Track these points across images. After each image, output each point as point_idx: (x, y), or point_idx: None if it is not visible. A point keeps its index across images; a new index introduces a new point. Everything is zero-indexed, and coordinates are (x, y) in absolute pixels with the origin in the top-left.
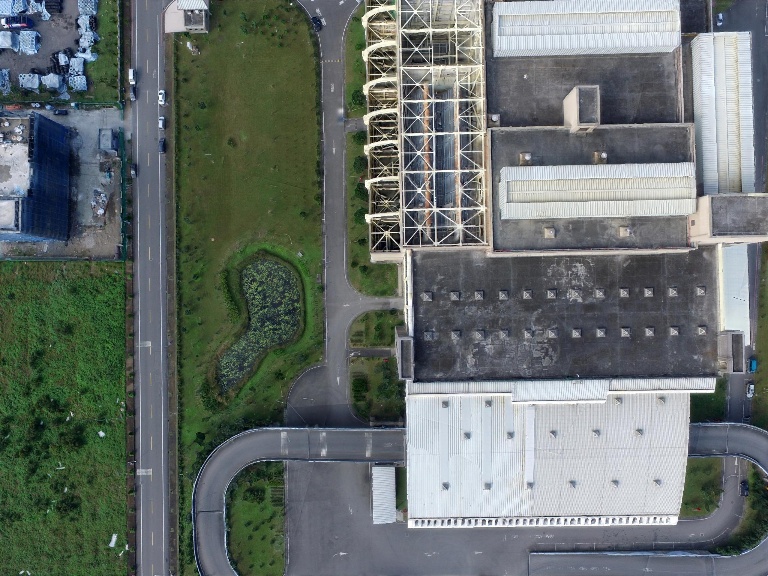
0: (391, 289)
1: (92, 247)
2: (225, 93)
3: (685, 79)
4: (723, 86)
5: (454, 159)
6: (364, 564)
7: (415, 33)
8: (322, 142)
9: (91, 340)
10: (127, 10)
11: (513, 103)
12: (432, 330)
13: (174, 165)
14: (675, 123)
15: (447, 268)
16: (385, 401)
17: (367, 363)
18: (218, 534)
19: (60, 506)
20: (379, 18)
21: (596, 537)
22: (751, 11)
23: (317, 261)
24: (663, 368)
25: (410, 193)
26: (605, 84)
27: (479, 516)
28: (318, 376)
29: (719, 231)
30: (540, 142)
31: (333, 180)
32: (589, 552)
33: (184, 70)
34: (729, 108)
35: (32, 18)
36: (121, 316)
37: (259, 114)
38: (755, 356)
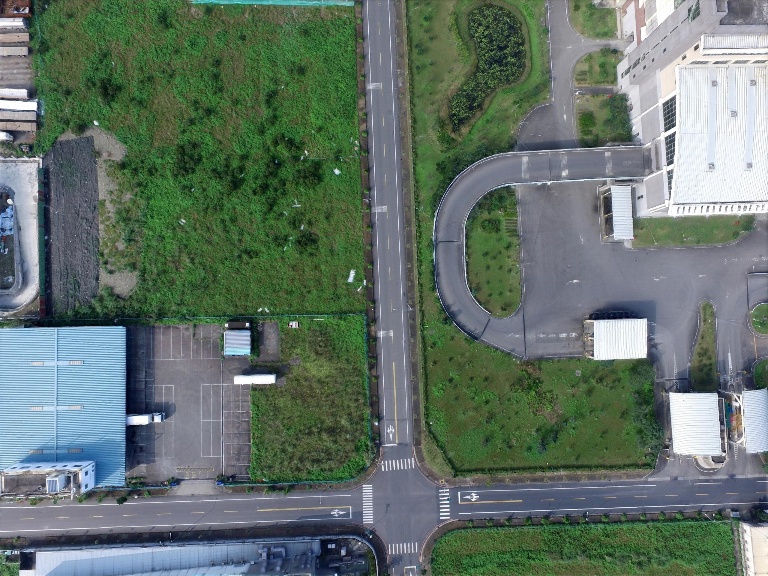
0: (611, 31)
1: None
2: None
3: None
4: None
5: None
6: (596, 290)
7: None
8: None
9: (324, 80)
10: None
11: None
12: None
13: None
14: None
15: None
16: (616, 129)
17: (592, 100)
18: (457, 264)
19: (300, 240)
20: None
21: None
22: None
23: (541, 6)
24: None
25: None
26: None
27: (737, 200)
28: (546, 114)
29: None
30: None
31: None
32: None
33: None
34: None
35: None
36: (353, 57)
37: None
38: None
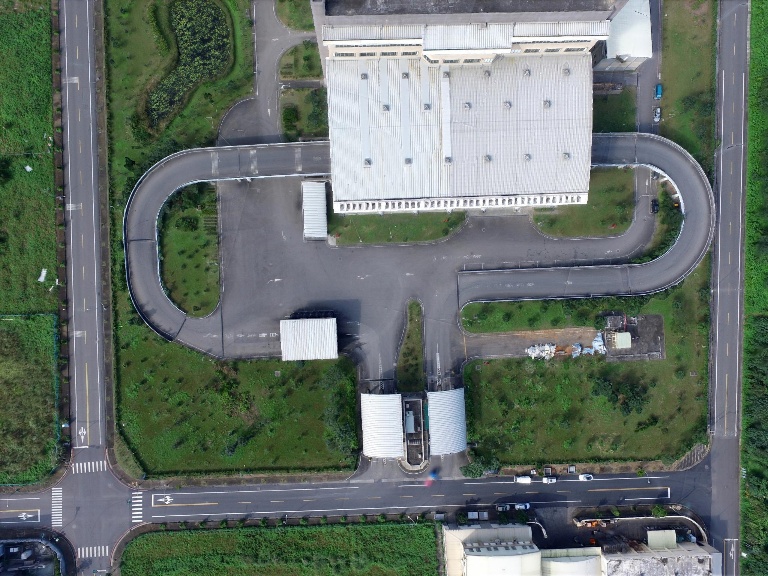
0: None
1: None
2: None
3: None
4: None
5: None
6: (299, 289)
7: None
8: None
9: (16, 75)
10: None
11: None
12: None
13: None
14: None
15: None
16: (314, 124)
17: (297, 94)
18: (151, 263)
19: None
20: None
21: (520, 256)
22: None
23: None
24: (560, 5)
25: None
26: None
27: (402, 197)
28: (249, 108)
29: None
30: None
31: None
32: (514, 269)
33: None
34: None
35: None
36: (47, 51)
37: None
38: (661, 84)
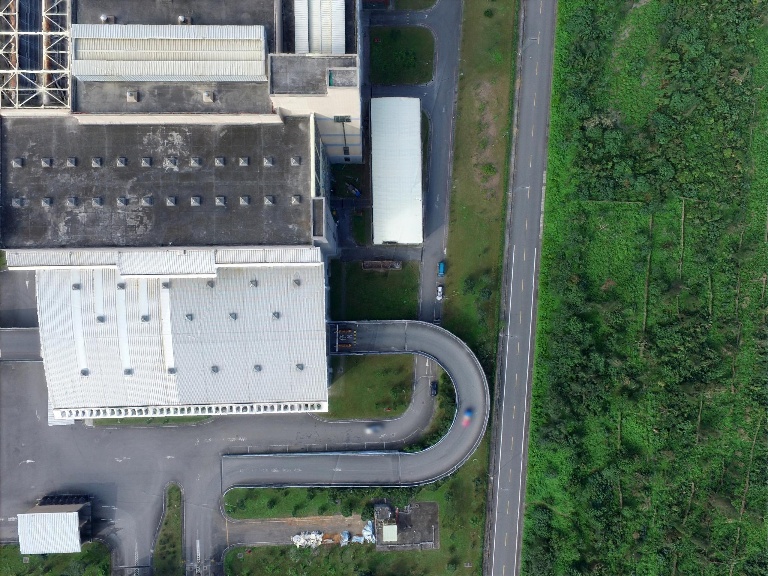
0: None
1: None
2: None
3: None
4: None
5: None
6: (52, 471)
7: None
8: None
9: None
10: None
11: None
12: (22, 197)
13: None
14: None
15: (39, 135)
16: None
17: None
18: None
19: None
20: None
21: (289, 439)
22: None
23: None
24: (258, 237)
25: None
26: None
27: (126, 405)
28: (6, 280)
29: (279, 90)
30: (126, 7)
31: None
32: (280, 453)
33: None
34: None
35: None
36: None
37: None
38: (446, 260)
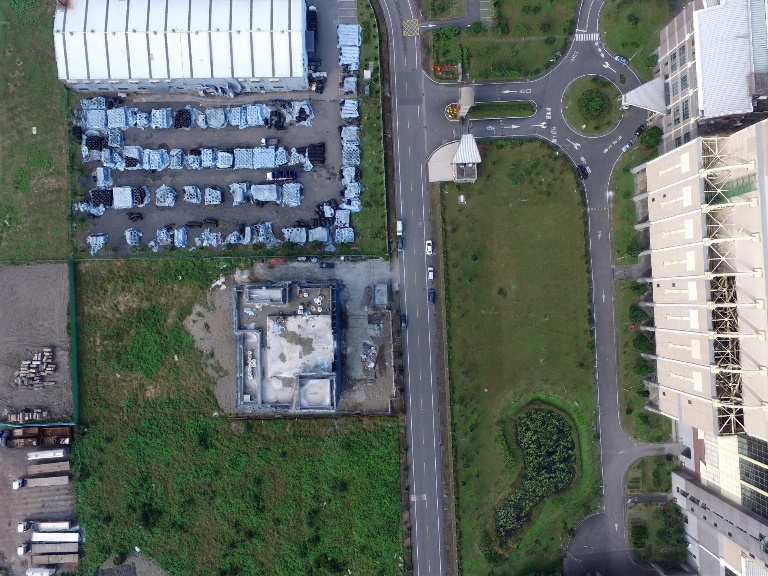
0: (666, 435)
1: (363, 401)
2: (493, 242)
3: None
4: None
5: None
6: None
7: None
8: (591, 290)
9: (367, 496)
10: (390, 159)
11: None
12: None
13: (444, 316)
14: None
15: None
16: (671, 550)
17: (645, 509)
18: None
19: None
20: (713, 201)
21: None
22: None
23: (591, 409)
24: None
25: None
26: None
27: None
28: (596, 523)
29: None
30: None
31: (604, 327)
32: None
33: (450, 220)
34: None
35: (294, 169)
36: (396, 470)
37: (528, 263)
38: None
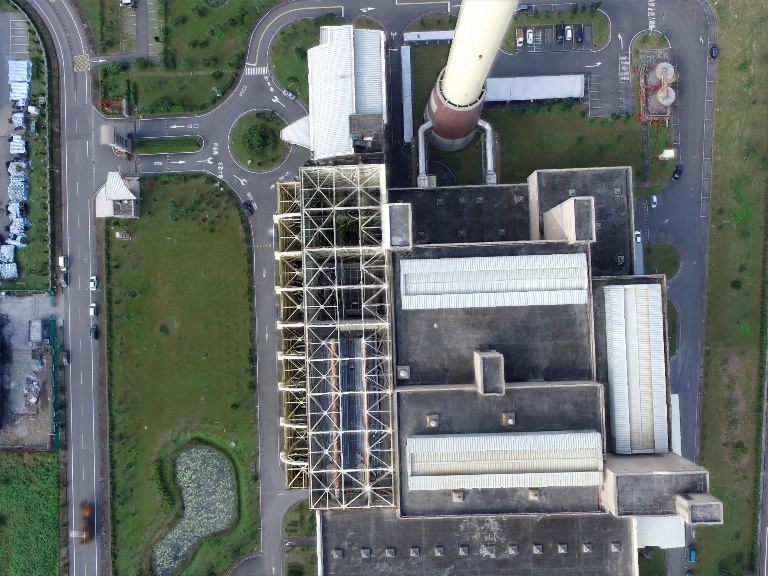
0: None
1: (25, 435)
2: (157, 279)
3: (599, 322)
4: (635, 338)
5: (363, 414)
6: None
7: (332, 258)
8: (255, 328)
9: (24, 531)
10: (58, 195)
11: (423, 353)
12: None
13: (106, 352)
14: (584, 384)
15: (358, 524)
16: None
17: (302, 553)
18: None
19: None
20: (294, 247)
21: None
22: (686, 192)
23: (251, 449)
24: None
25: (317, 454)
26: (516, 333)
27: None
28: (253, 566)
29: (625, 510)
30: (448, 402)
31: (266, 366)
32: None
33: (115, 255)
34: (641, 361)
35: None
36: (54, 506)
37: (191, 300)
38: (695, 544)
